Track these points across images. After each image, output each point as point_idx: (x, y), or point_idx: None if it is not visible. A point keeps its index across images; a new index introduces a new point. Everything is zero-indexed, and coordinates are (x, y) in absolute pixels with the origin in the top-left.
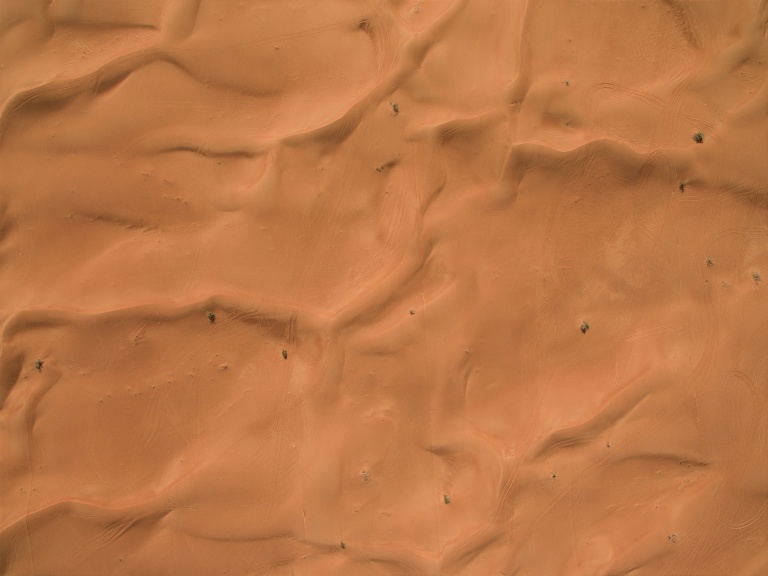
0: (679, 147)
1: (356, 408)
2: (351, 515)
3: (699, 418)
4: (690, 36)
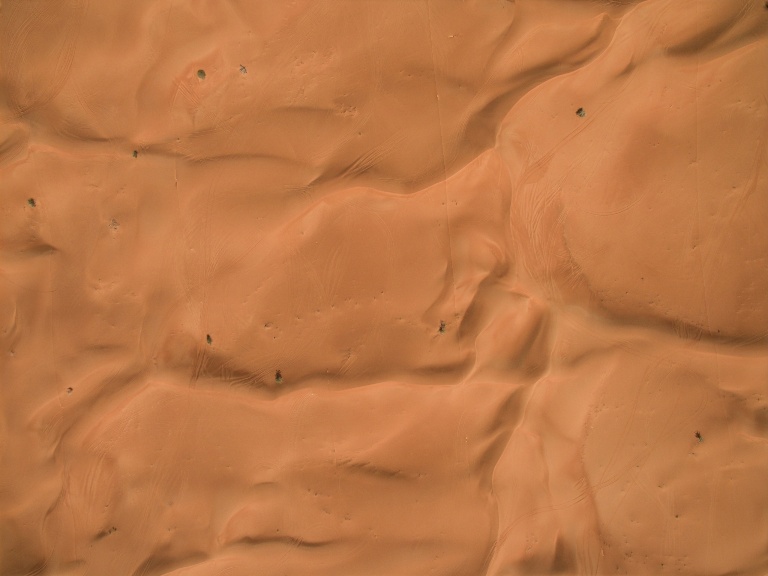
0: None
1: (129, 291)
2: (128, 185)
3: None
4: None
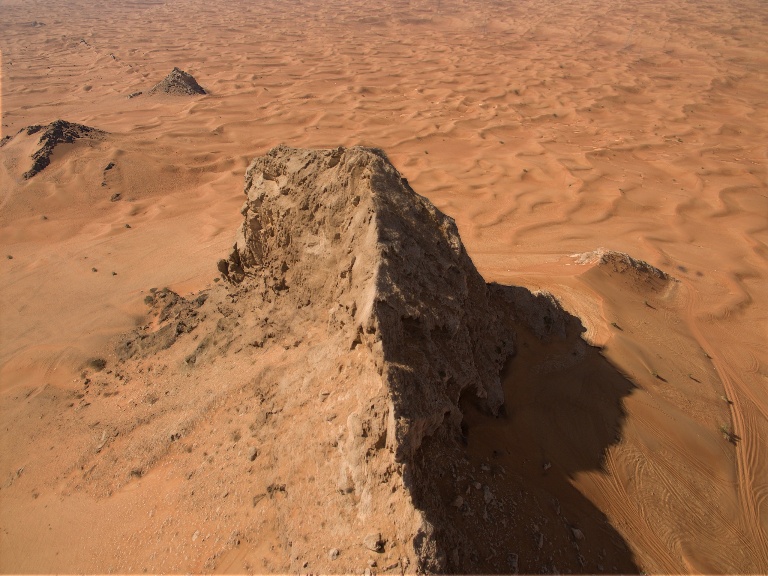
0: None
1: None
2: None
3: None
4: None
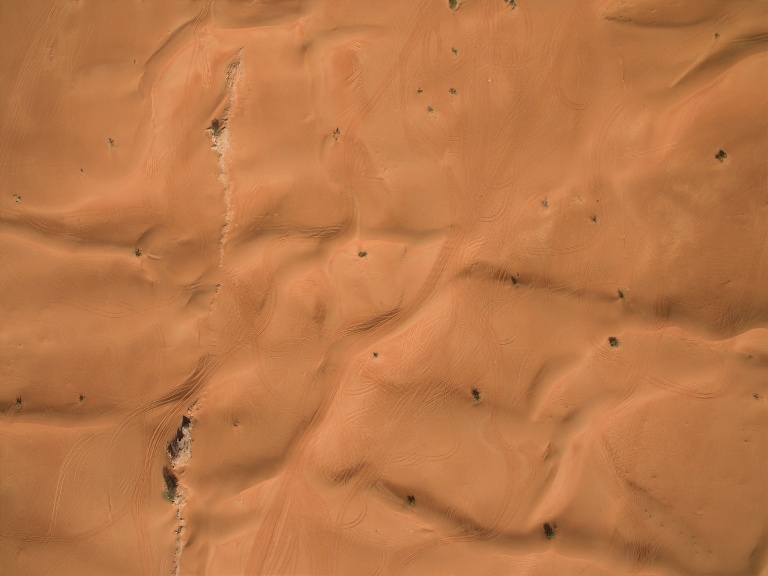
0: (635, 333)
1: None
2: None
3: (620, 63)
4: (608, 447)
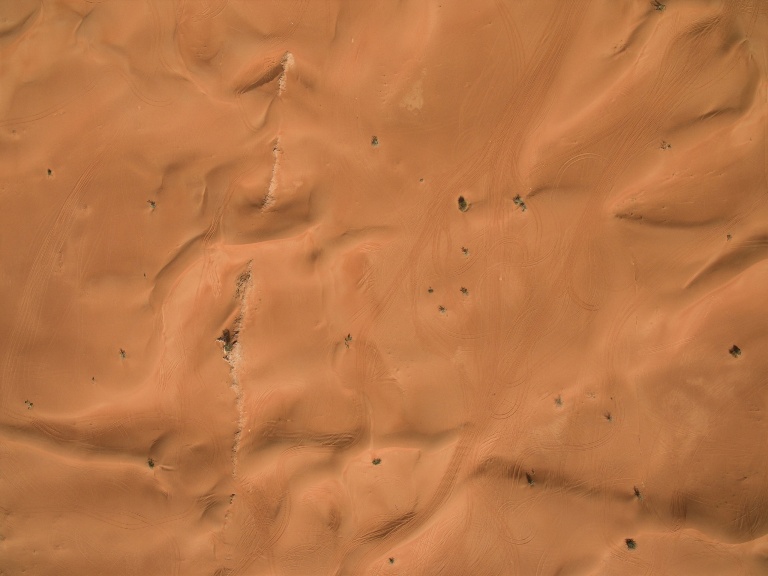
0: (652, 535)
1: None
2: None
3: (632, 264)
4: None
